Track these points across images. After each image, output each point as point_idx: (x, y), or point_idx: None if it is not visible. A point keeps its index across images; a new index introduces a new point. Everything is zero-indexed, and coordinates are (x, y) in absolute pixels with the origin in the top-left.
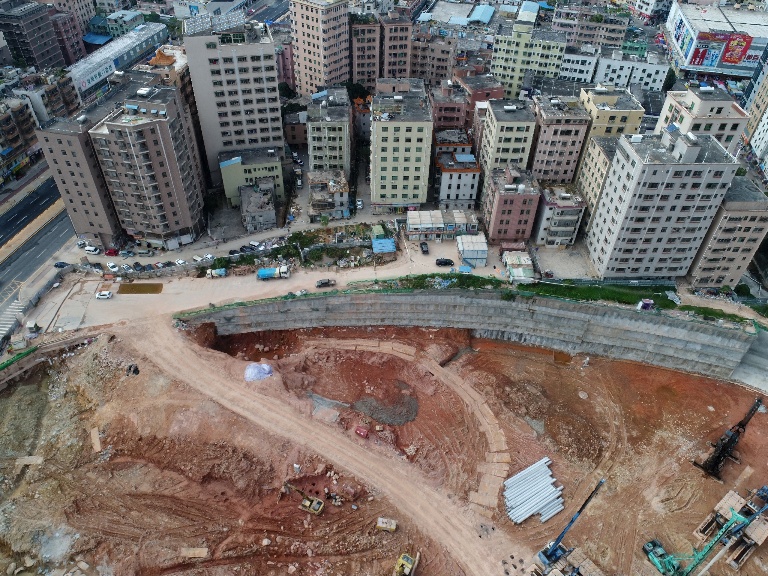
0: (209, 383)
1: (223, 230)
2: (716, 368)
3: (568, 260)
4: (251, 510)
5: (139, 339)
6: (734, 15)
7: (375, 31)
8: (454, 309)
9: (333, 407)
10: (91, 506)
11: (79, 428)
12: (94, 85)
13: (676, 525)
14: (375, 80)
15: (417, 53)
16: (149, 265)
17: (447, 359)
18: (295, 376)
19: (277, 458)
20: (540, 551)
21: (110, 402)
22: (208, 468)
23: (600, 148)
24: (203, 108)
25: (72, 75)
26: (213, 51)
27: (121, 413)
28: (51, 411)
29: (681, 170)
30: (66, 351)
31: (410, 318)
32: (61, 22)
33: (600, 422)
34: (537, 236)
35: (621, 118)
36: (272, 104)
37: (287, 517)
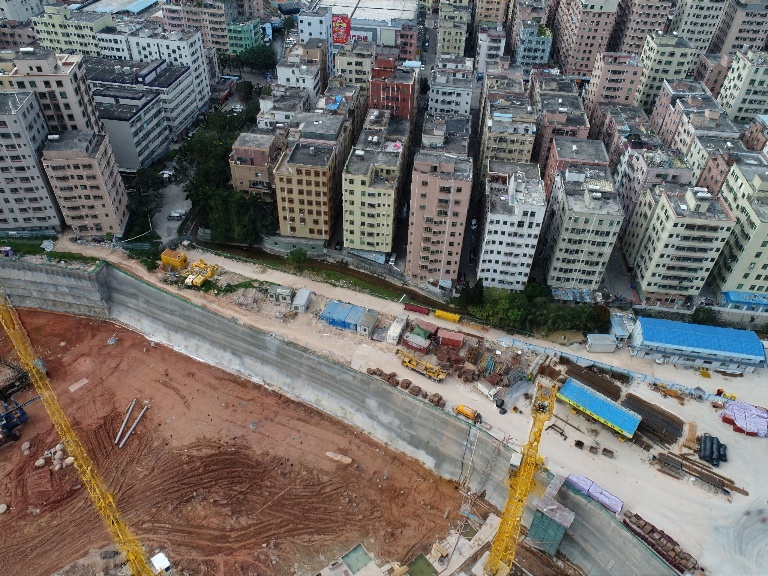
0: None
1: None
2: (95, 309)
3: None
4: None
5: None
6: (369, 1)
7: None
8: None
9: None
10: None
11: None
12: None
13: None
14: None
15: (8, 39)
16: None
17: None
18: None
19: None
20: None
21: None
22: None
23: None
24: None
25: None
26: None
27: None
28: None
29: None
30: None
31: None
32: None
33: None
34: None
35: (9, 83)
36: None
37: None
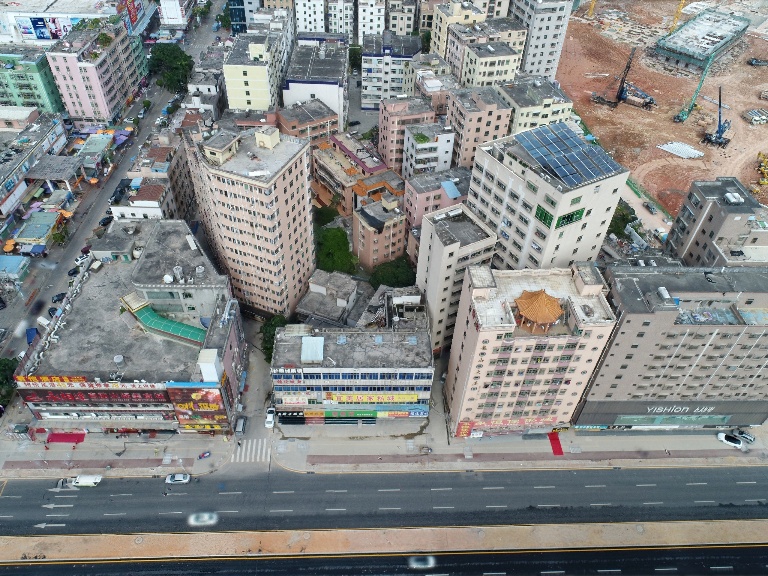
0: None
1: None
2: None
3: None
4: None
5: None
6: None
7: None
8: None
9: None
10: None
11: None
12: None
13: None
14: None
15: (176, 176)
16: None
17: None
18: None
19: None
20: None
21: None
22: None
23: (509, 31)
24: None
25: None
26: None
27: None
28: None
29: None
30: None
31: None
32: None
33: (612, 133)
34: None
35: None
36: None
37: None
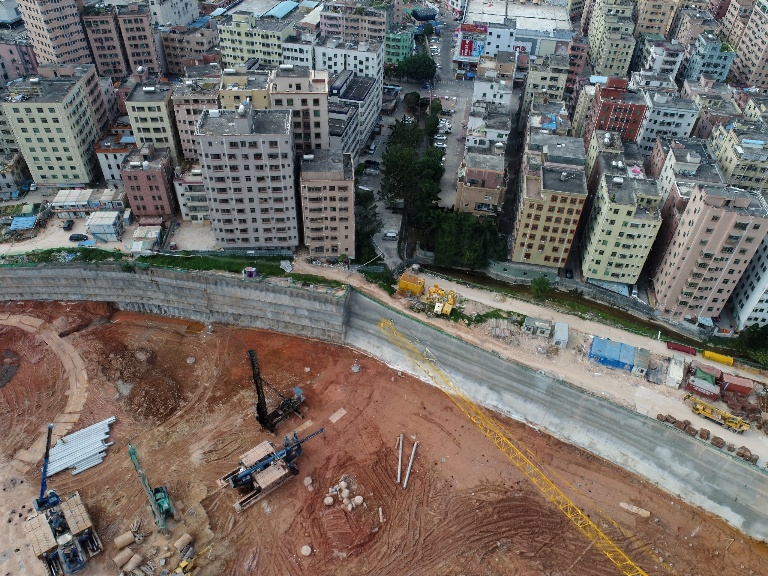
0: None
1: None
2: (330, 333)
3: (205, 234)
4: None
5: None
6: (516, 9)
7: (108, 22)
8: (85, 282)
9: None
10: None
11: None
12: None
13: (204, 474)
14: (122, 71)
15: (175, 45)
16: None
17: (71, 330)
18: None
19: None
20: None
21: None
22: None
23: None
24: None
25: None
26: None
27: None
28: None
29: (234, 141)
30: None
31: (47, 292)
32: None
33: (191, 384)
34: (181, 212)
35: (246, 97)
36: None
37: None
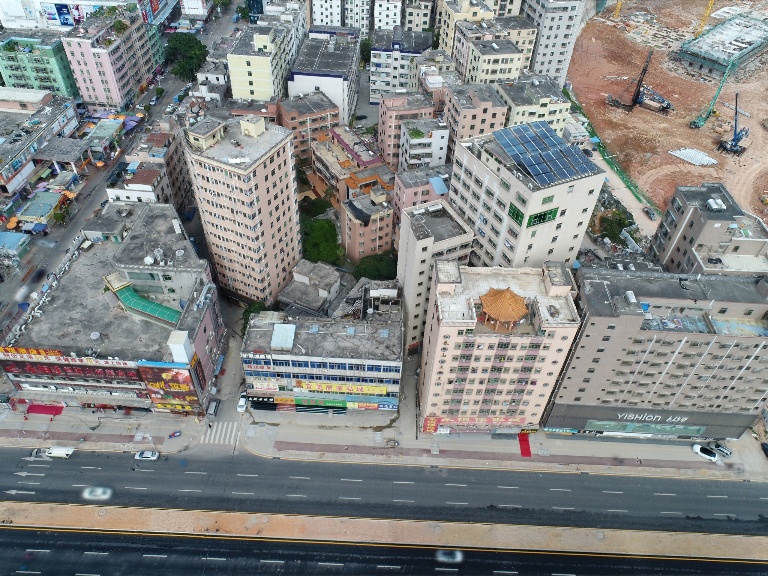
0: None
1: None
2: None
3: None
4: None
5: None
6: None
7: None
8: None
9: None
10: None
11: None
12: None
13: None
14: None
15: (174, 162)
16: None
17: None
18: None
19: None
20: None
21: None
22: None
23: (519, 29)
24: None
25: None
26: None
27: None
28: None
29: None
30: None
31: None
32: None
33: (624, 137)
34: None
35: None
36: None
37: None
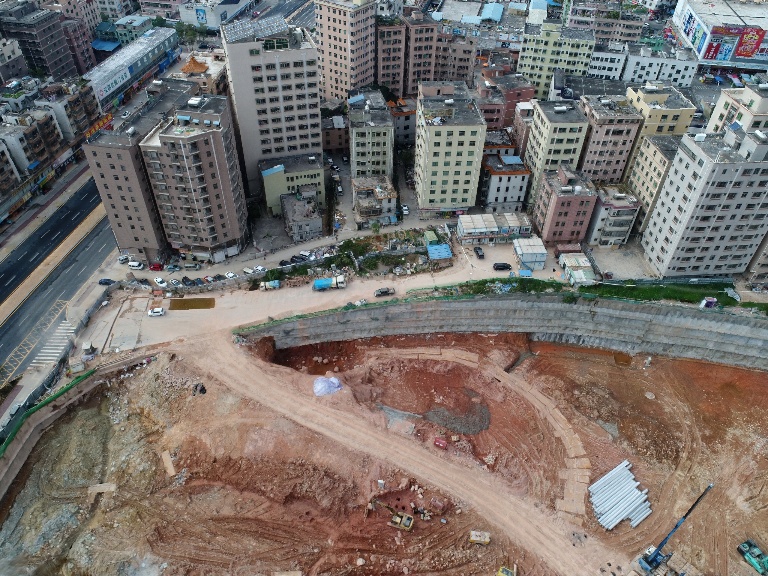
0: (279, 399)
1: (269, 240)
2: None
3: (623, 260)
4: (339, 529)
5: (201, 357)
6: (741, 9)
7: (401, 32)
8: (514, 313)
9: (407, 419)
10: (174, 533)
11: (149, 452)
12: (111, 93)
13: (764, 524)
14: (399, 82)
15: (438, 53)
16: (198, 279)
17: (511, 364)
18: (363, 388)
19: (359, 474)
20: (637, 557)
21: (178, 423)
22: (290, 488)
23: (656, 147)
24: (244, 116)
25: (92, 84)
26: (256, 58)
27: (192, 434)
28: (116, 435)
29: (750, 168)
30: (124, 372)
31: (469, 324)
32: (71, 29)
33: (671, 422)
34: (590, 237)
35: (673, 116)
36: (312, 110)
37: (377, 535)
